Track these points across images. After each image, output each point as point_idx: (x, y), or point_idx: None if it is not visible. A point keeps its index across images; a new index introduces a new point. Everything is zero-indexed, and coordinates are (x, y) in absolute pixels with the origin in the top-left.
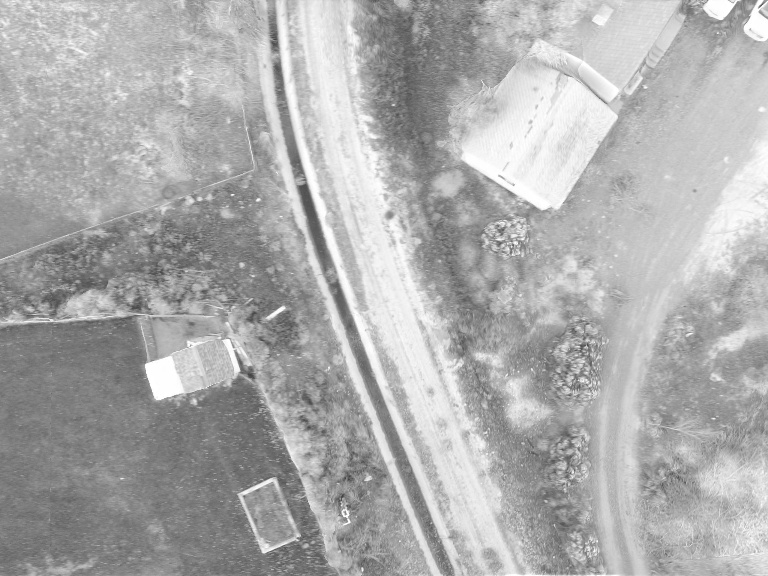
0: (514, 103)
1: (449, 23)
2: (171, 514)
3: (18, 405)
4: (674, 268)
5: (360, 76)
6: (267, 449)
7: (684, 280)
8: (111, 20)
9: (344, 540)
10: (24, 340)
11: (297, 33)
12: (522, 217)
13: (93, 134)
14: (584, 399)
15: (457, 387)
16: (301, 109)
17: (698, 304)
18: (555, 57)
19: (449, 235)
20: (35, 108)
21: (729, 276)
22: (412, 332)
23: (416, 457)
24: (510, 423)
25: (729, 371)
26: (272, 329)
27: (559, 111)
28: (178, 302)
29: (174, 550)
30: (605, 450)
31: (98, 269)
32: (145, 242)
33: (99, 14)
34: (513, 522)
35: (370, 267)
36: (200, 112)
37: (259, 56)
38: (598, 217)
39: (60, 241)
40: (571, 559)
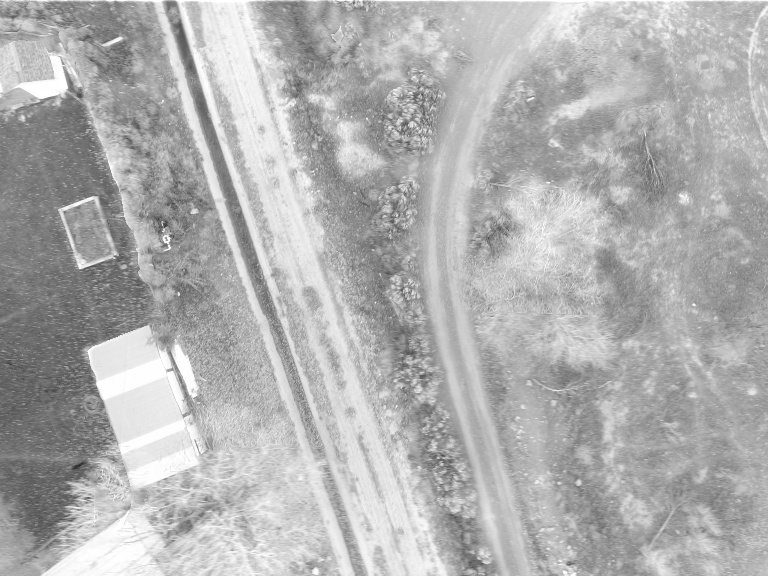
0: None
1: None
2: None
3: None
4: (520, 35)
5: None
6: (91, 169)
7: (530, 47)
8: None
9: (161, 262)
10: None
11: None
12: None
13: None
14: (414, 146)
15: (287, 125)
16: None
17: (542, 71)
18: None
19: None
20: None
21: (575, 46)
22: (247, 70)
23: (244, 194)
24: (341, 168)
25: (568, 138)
26: (105, 53)
27: None
28: (12, 18)
29: None
30: (437, 205)
31: None
32: None
33: None
34: (334, 261)
35: (210, 4)
36: None
37: None
38: None
39: None
40: (394, 308)
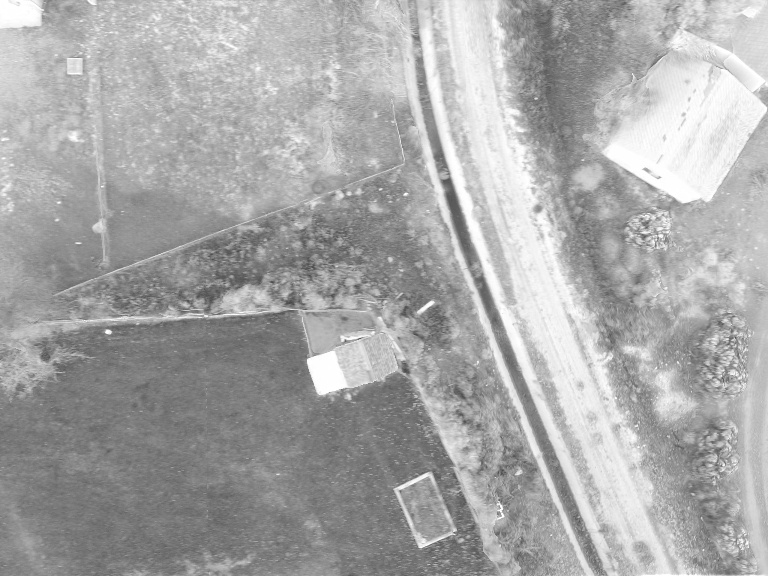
0: (665, 96)
1: (587, 16)
2: (327, 509)
3: (173, 401)
4: None
5: (506, 70)
6: (421, 444)
7: None
8: (261, 14)
9: (500, 534)
10: (178, 336)
11: (441, 27)
12: (665, 210)
13: (244, 129)
14: (733, 392)
15: (607, 380)
16: (446, 103)
17: None
18: (704, 49)
19: (591, 229)
20: (187, 103)
21: None
22: (561, 326)
23: (565, 451)
24: (658, 416)
25: None
26: (424, 323)
27: (712, 103)
28: (332, 297)
29: (331, 545)
30: (750, 443)
31: (251, 264)
32: (297, 237)
33: (249, 8)
34: (665, 515)
35: (518, 261)
36: (348, 106)
37: (403, 50)
38: (737, 210)
39: (213, 236)
40: (719, 552)
